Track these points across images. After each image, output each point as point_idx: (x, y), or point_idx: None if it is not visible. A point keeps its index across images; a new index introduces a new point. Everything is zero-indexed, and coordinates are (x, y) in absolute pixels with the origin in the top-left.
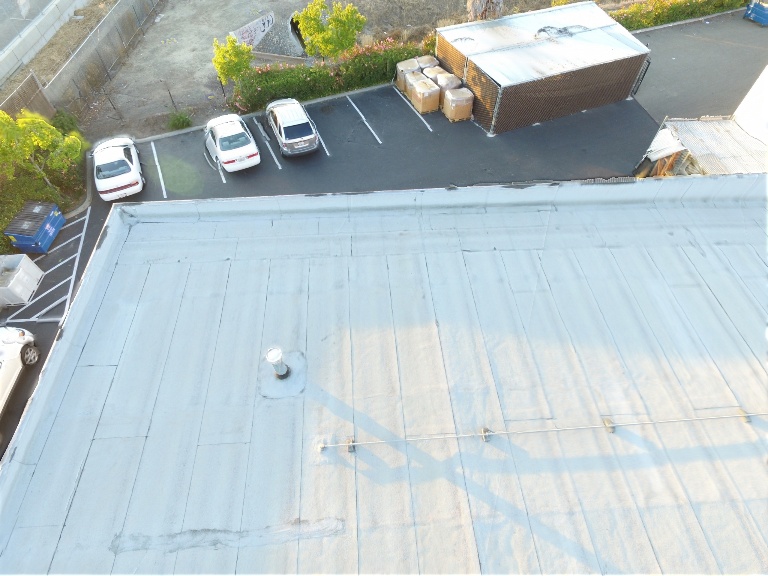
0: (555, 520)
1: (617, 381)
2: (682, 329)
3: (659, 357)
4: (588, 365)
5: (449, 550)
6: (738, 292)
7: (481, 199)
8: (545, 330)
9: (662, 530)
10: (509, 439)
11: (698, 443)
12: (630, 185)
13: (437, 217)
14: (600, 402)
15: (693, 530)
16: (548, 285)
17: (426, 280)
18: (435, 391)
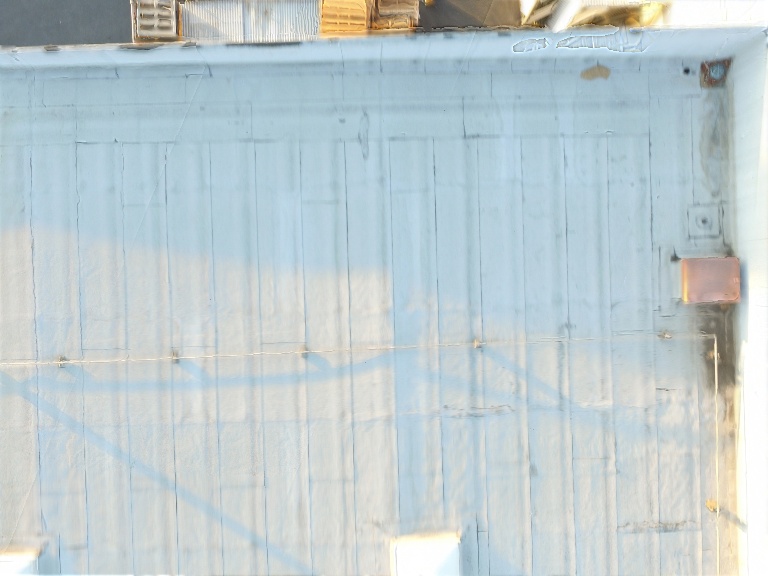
0: (105, 431)
1: (200, 314)
2: (291, 257)
3: (252, 289)
4: (178, 296)
5: (19, 448)
6: (375, 212)
7: (104, 59)
8: (146, 255)
9: (186, 441)
10: (82, 366)
11: (249, 375)
12: (295, 46)
13: (54, 84)
14: (176, 334)
15: (211, 442)
16: (164, 197)
17: (27, 187)
18: (23, 319)
